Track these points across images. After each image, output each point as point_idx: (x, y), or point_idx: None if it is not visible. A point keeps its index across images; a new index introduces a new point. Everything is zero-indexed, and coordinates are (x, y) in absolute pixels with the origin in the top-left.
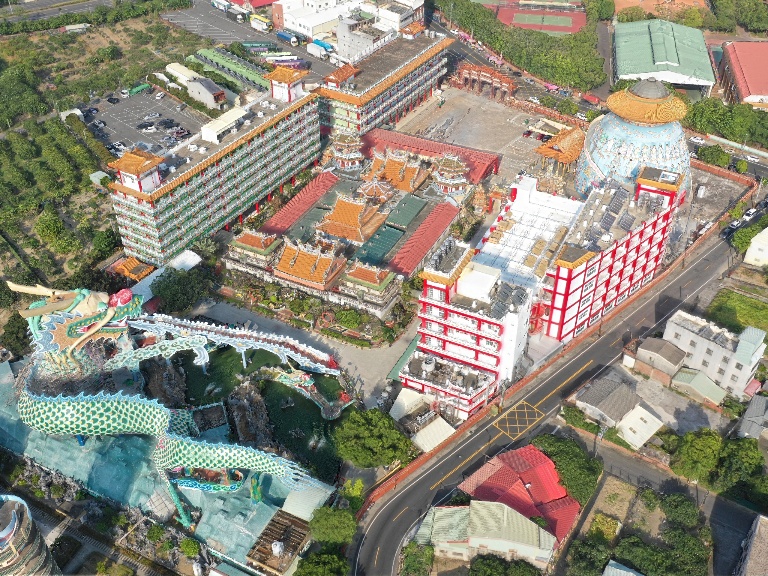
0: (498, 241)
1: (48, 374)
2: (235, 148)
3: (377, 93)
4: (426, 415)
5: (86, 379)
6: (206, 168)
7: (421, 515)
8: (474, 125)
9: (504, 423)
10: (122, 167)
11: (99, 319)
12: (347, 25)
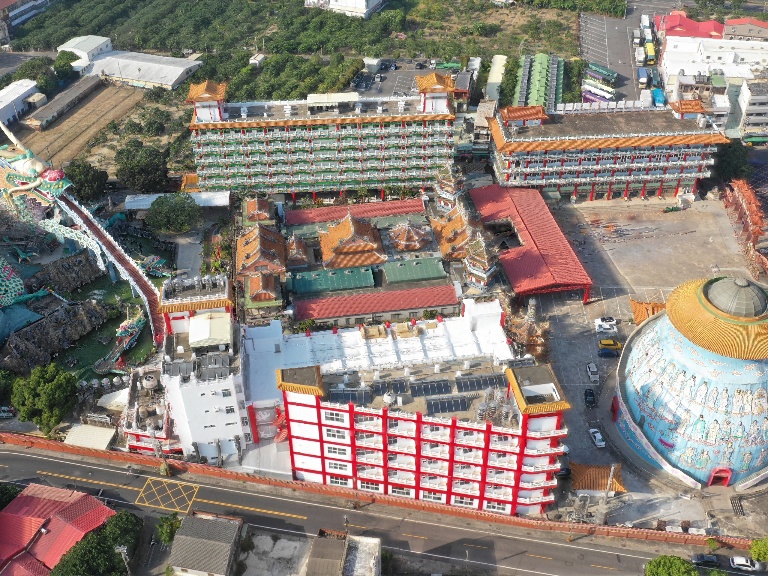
0: (371, 338)
1: (3, 203)
2: (316, 125)
3: (535, 148)
4: (96, 415)
5: (19, 222)
6: (273, 128)
7: (2, 479)
8: (665, 248)
9: (155, 485)
10: (193, 91)
11: (30, 181)
12: (679, 82)
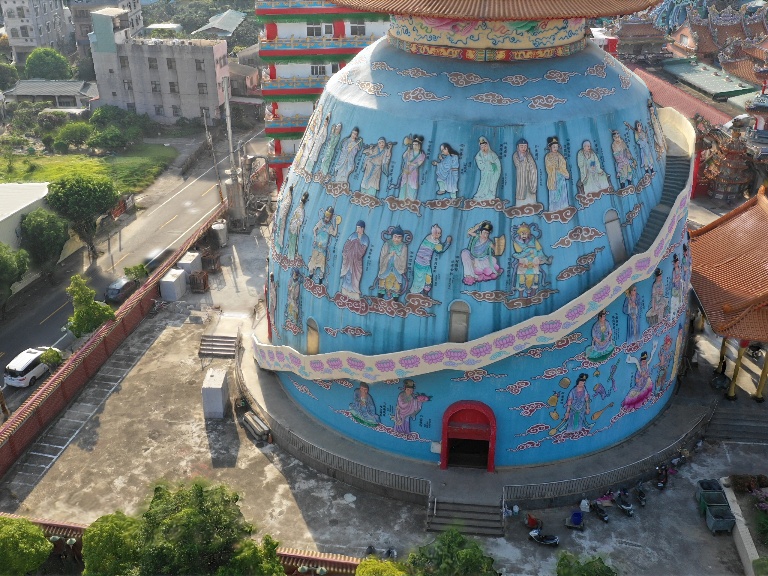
0: None
1: None
2: None
3: None
4: None
5: None
6: None
7: None
8: None
9: None
10: None
11: None
12: None
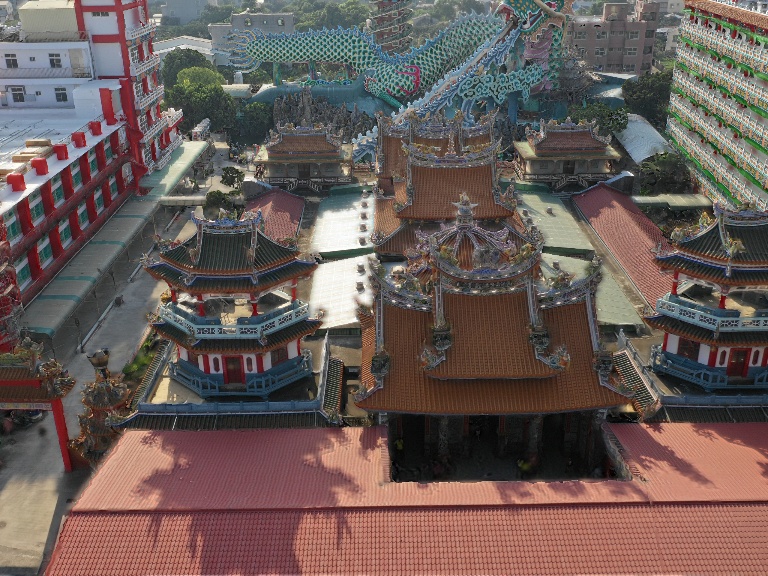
0: None
1: None
2: None
3: None
4: None
5: None
6: None
7: None
8: None
9: None
10: None
11: None
12: None
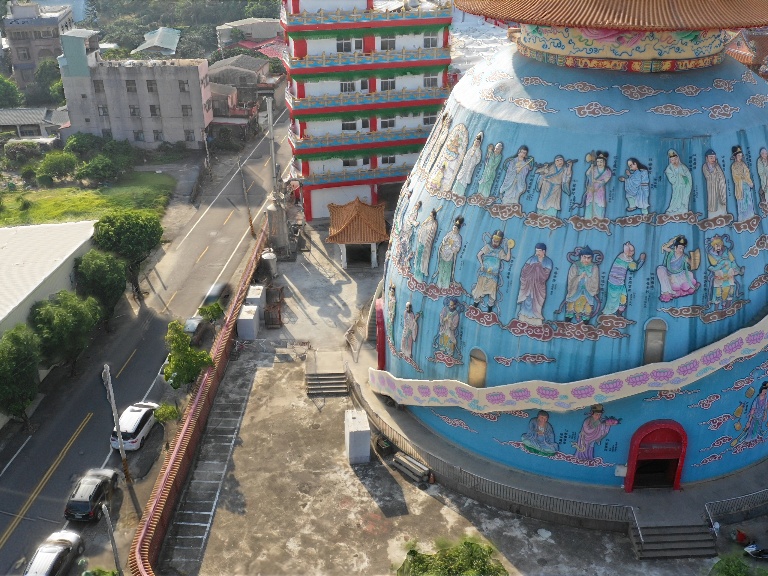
0: (514, 41)
1: None
2: None
3: None
4: None
5: None
6: None
7: None
8: None
9: None
10: None
11: None
12: None
